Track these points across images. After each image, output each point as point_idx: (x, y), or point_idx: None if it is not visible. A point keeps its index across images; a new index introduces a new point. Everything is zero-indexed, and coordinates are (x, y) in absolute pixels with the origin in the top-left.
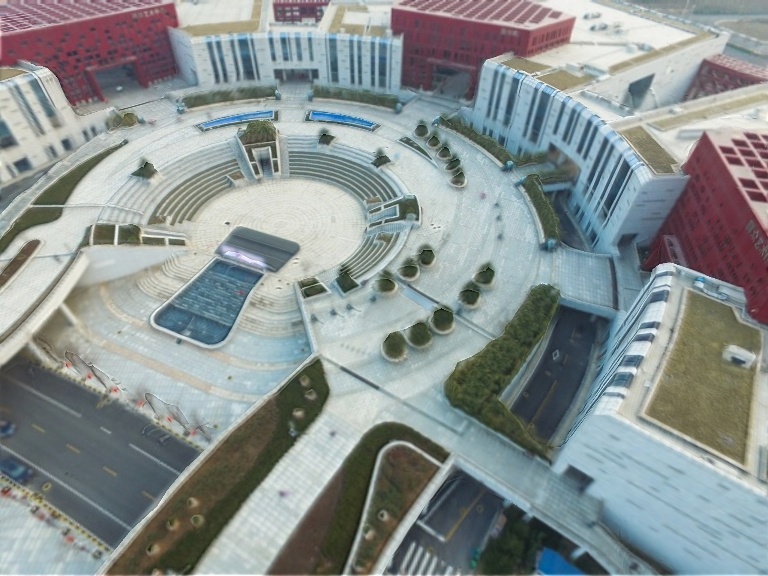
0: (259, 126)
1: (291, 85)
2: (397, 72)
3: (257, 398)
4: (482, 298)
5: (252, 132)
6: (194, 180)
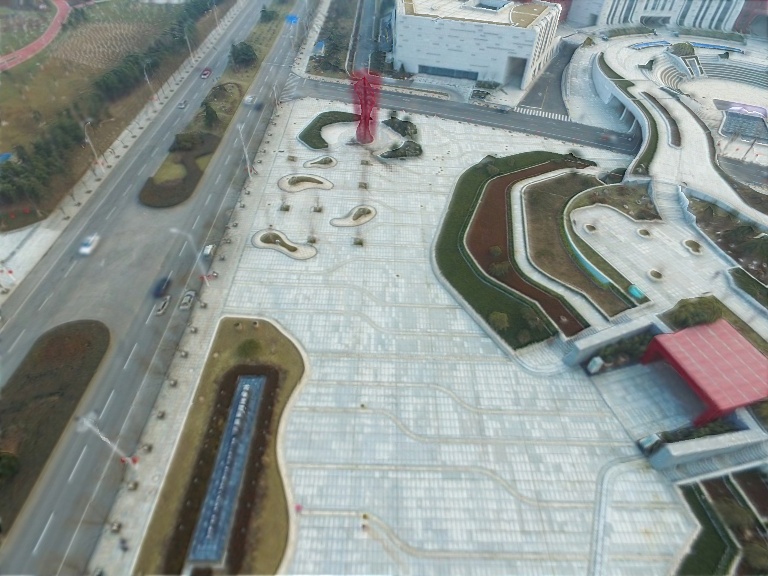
0: (686, 45)
1: (650, 28)
2: (734, 18)
3: None
4: None
5: (684, 48)
6: (664, 75)
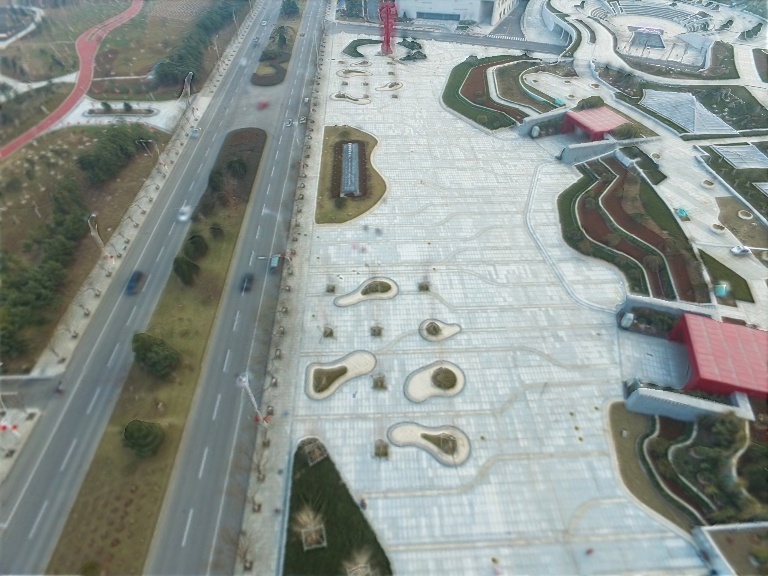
0: None
1: None
2: None
3: (694, 57)
4: (761, 31)
5: None
6: None
